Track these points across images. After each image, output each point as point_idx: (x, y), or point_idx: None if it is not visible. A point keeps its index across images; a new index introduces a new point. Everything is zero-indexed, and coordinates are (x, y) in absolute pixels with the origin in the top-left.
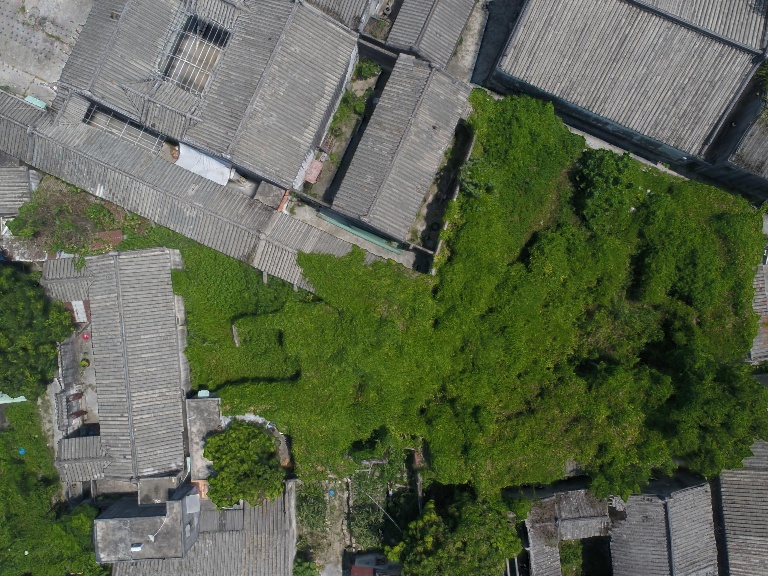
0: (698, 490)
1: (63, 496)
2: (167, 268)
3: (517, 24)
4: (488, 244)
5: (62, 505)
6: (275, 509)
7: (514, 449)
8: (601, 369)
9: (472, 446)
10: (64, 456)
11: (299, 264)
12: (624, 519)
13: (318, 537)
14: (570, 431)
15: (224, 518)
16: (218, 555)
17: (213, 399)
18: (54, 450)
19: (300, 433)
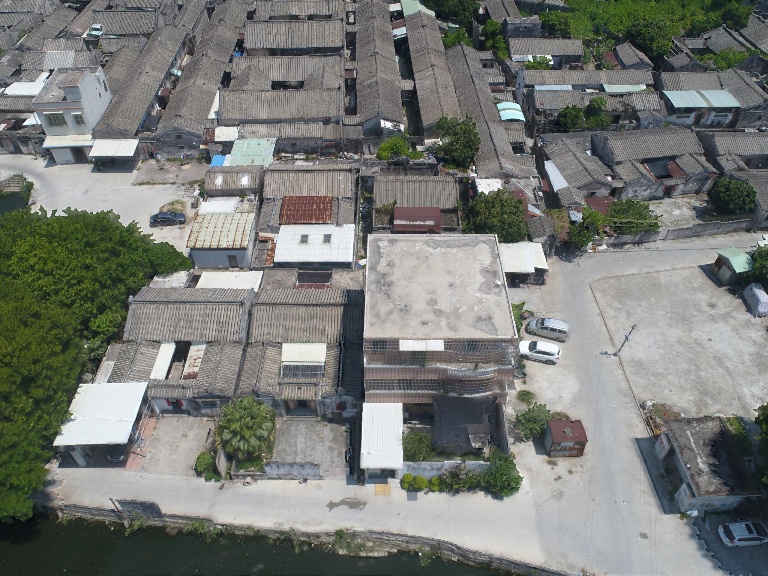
0: (736, 34)
1: None
2: (514, 2)
3: None
4: (629, 2)
5: None
6: None
7: None
8: None
9: None
10: None
11: None
12: (710, 38)
13: None
14: None
15: None
16: None
17: None
18: None
19: None
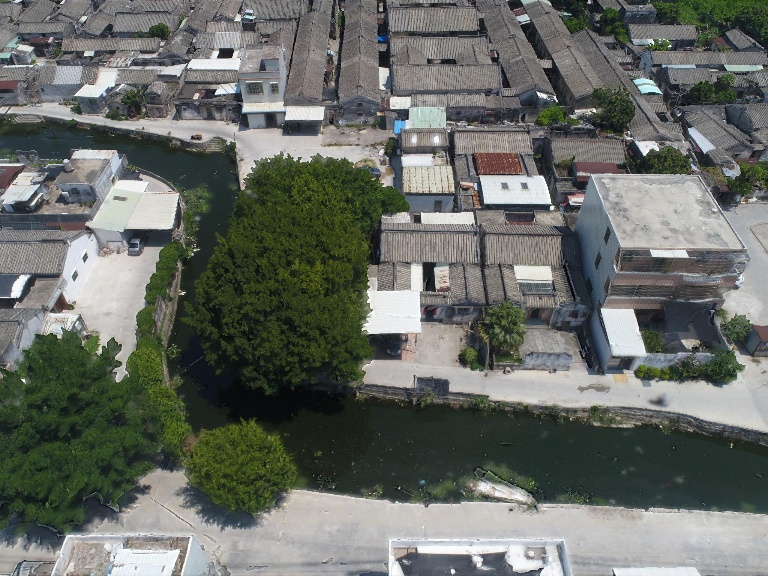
0: None
1: None
2: None
3: None
4: None
5: None
6: None
7: None
8: None
9: None
10: None
11: None
12: None
13: None
14: None
15: None
16: None
17: None
18: None
19: None
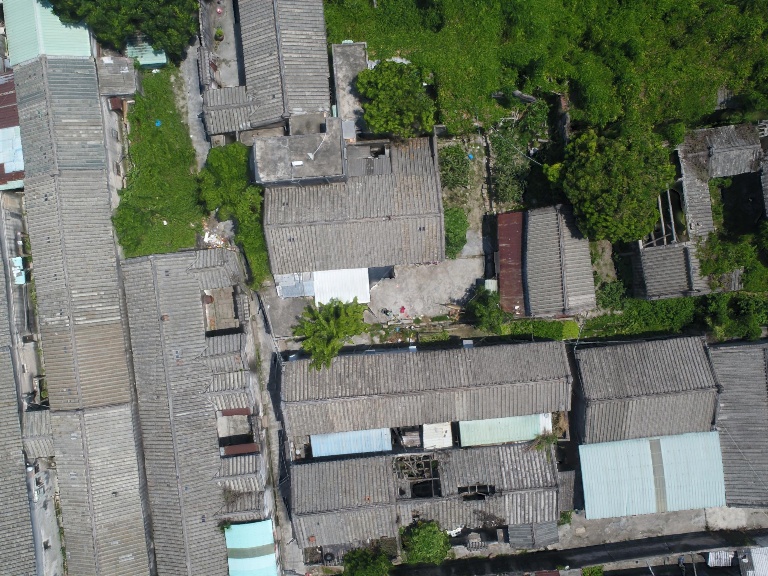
0: None
1: (198, 172)
2: None
3: None
4: None
5: (198, 180)
6: (422, 155)
7: (668, 73)
8: None
9: (625, 72)
10: (210, 104)
11: None
12: None
13: (458, 202)
14: (722, 57)
15: (371, 165)
16: (369, 194)
17: (359, 43)
18: (188, 127)
19: (447, 76)
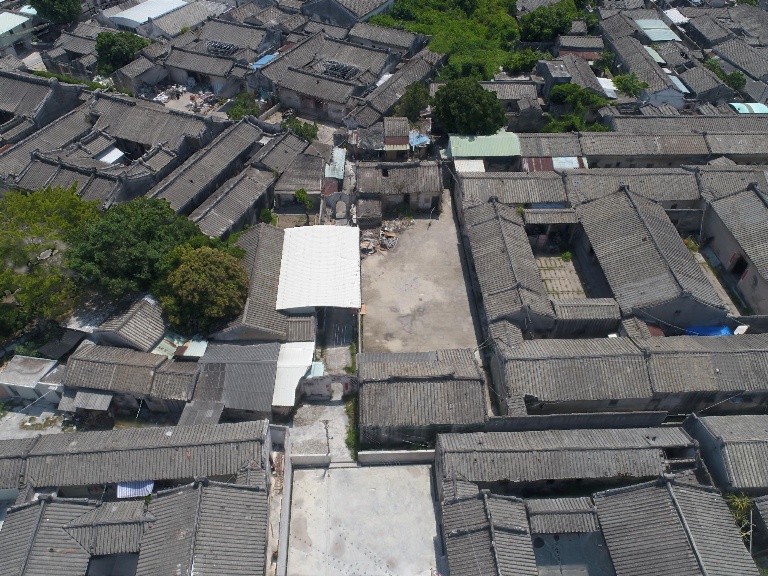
0: None
1: None
2: None
3: (346, 8)
4: None
5: None
6: None
7: None
8: (471, 6)
9: (503, 24)
10: None
11: (433, 51)
12: (525, 7)
13: None
14: (494, 12)
15: None
16: None
17: None
18: None
19: None
